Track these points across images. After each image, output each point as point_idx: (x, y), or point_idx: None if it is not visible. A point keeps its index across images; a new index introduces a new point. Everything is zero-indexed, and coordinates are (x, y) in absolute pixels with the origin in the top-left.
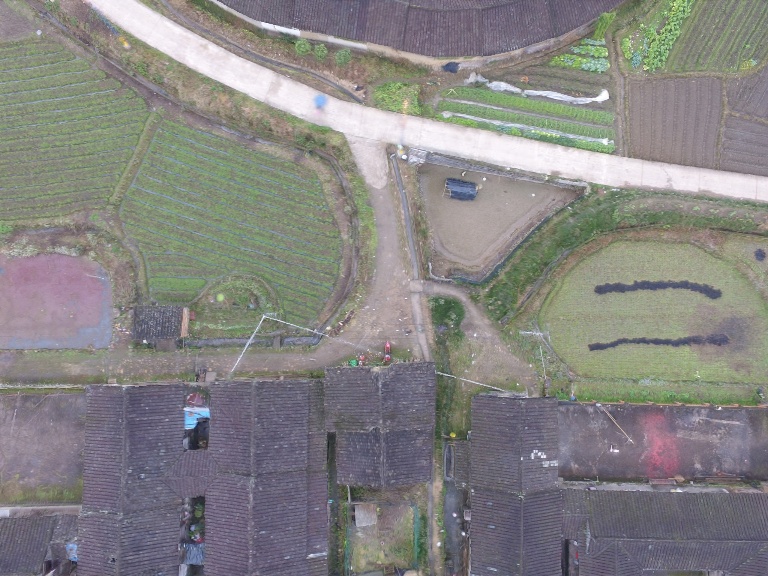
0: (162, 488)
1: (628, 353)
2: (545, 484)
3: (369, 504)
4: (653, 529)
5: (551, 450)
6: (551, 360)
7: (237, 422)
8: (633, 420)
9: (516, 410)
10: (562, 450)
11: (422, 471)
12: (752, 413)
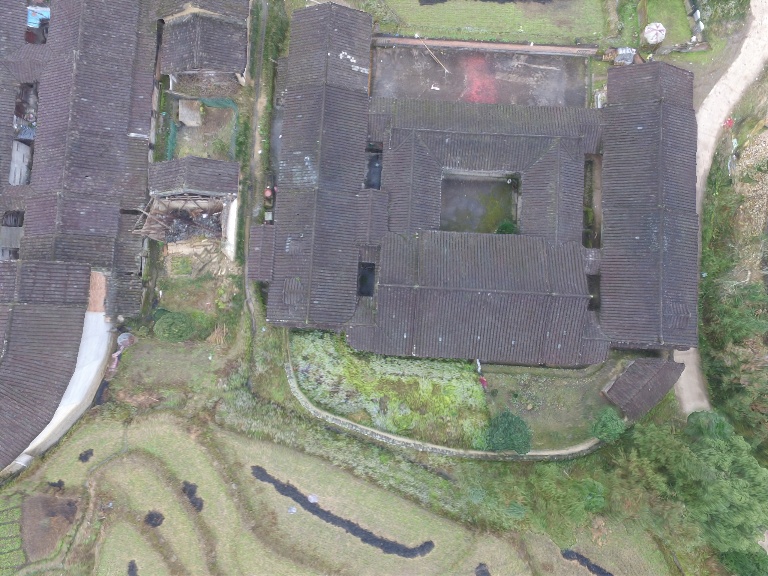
0: (1, 69)
1: (456, 9)
2: (353, 85)
3: (193, 103)
4: (451, 125)
5: (362, 58)
6: (379, 6)
7: (70, 12)
8: (455, 63)
9: (326, 12)
10: (386, 87)
11: (237, 62)
12: (569, 60)
